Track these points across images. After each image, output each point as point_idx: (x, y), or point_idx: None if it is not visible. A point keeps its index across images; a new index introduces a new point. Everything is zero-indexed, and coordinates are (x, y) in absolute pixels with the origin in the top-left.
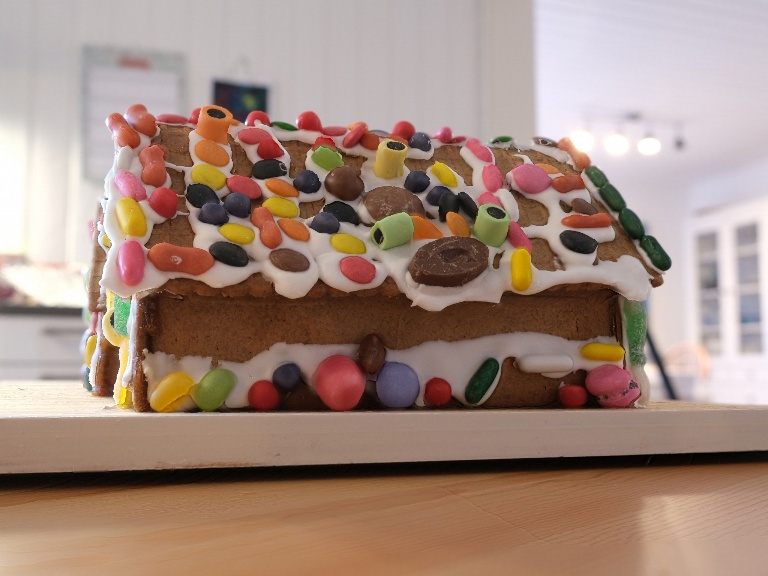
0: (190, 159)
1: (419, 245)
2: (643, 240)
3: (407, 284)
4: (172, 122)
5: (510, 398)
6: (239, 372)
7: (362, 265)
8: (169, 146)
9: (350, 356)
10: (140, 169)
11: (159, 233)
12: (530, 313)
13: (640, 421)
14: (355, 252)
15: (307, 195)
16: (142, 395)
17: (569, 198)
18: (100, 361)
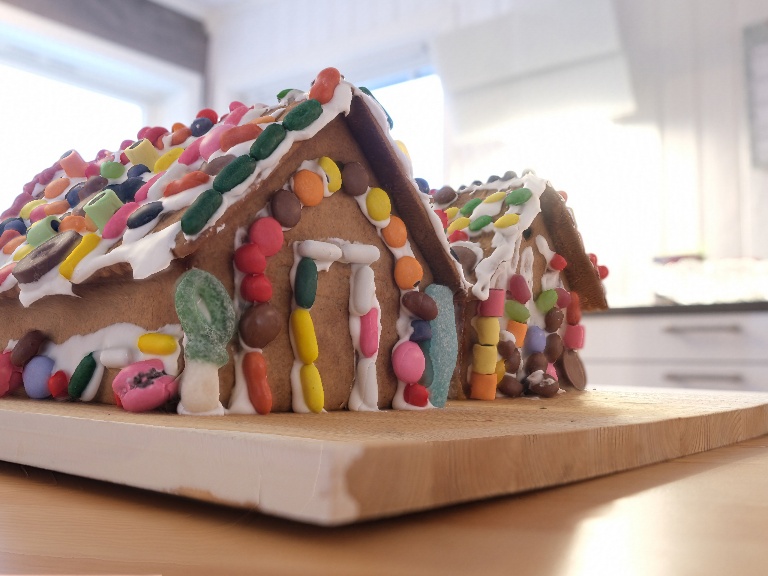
0: None
1: None
2: None
3: None
4: None
5: (114, 395)
6: None
7: (4, 270)
8: None
9: None
10: None
11: None
12: (128, 302)
13: (19, 424)
14: None
15: (71, 210)
16: None
17: None
18: None
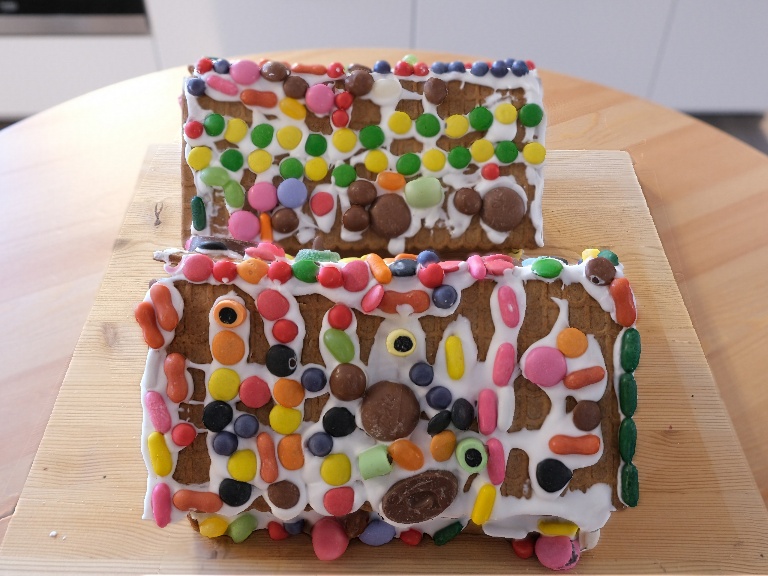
0: (210, 352)
1: (397, 476)
2: (626, 468)
3: (380, 511)
4: (196, 280)
5: (475, 531)
6: (260, 515)
7: (341, 503)
8: (191, 336)
9: (340, 521)
10: (165, 383)
11: (184, 458)
12: None
13: None
14: (339, 483)
15: (312, 394)
16: (194, 523)
17: (577, 397)
18: None
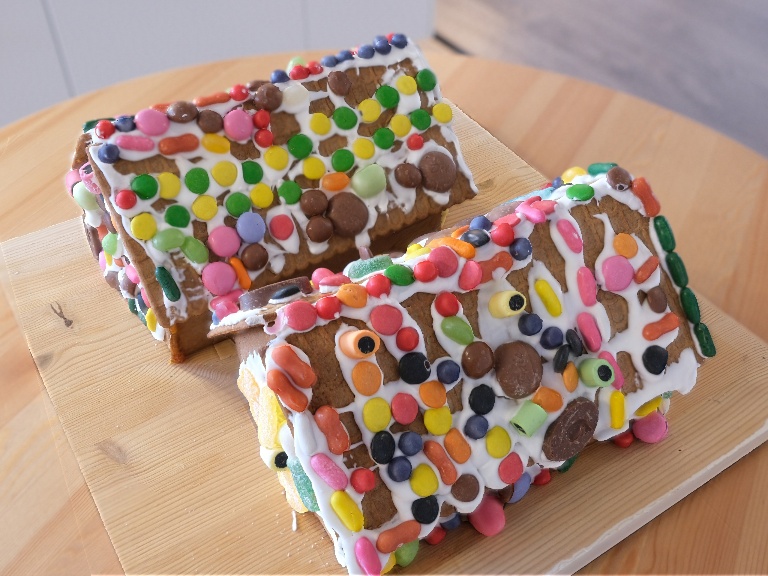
0: (350, 391)
1: (548, 422)
2: (698, 328)
3: (542, 460)
4: (307, 328)
5: None
6: None
7: (515, 469)
8: (328, 384)
9: (492, 493)
10: (325, 441)
11: (366, 504)
12: None
13: None
14: (506, 453)
15: (451, 386)
16: None
17: (646, 288)
18: (172, 339)
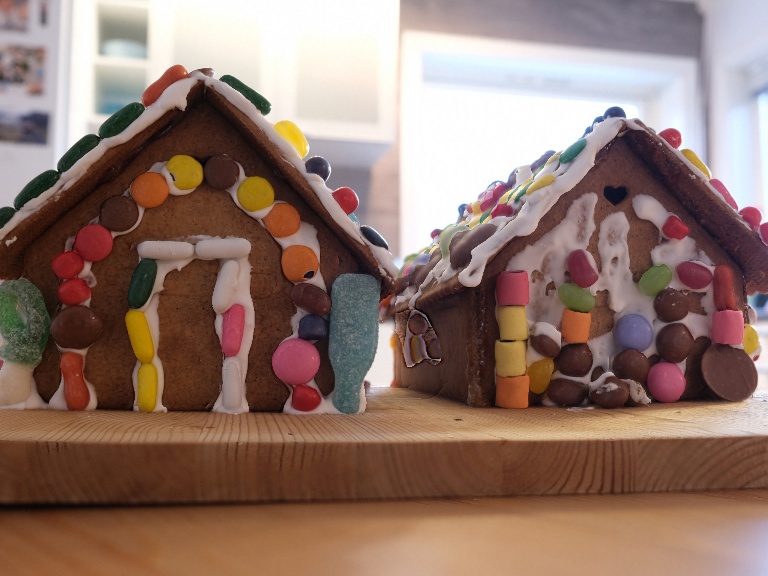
0: None
1: None
2: None
3: None
4: None
5: None
6: None
7: None
8: None
9: None
10: None
11: None
12: None
13: None
14: None
15: None
16: None
17: None
18: None
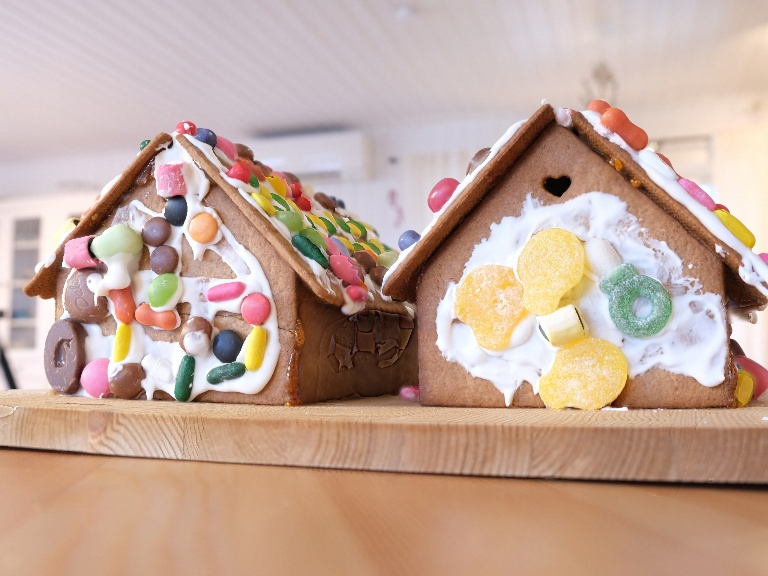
0: None
1: None
2: None
3: None
4: None
5: None
6: None
7: None
8: None
9: None
10: None
11: None
12: None
13: None
14: None
15: None
16: (734, 392)
17: None
18: (294, 360)
